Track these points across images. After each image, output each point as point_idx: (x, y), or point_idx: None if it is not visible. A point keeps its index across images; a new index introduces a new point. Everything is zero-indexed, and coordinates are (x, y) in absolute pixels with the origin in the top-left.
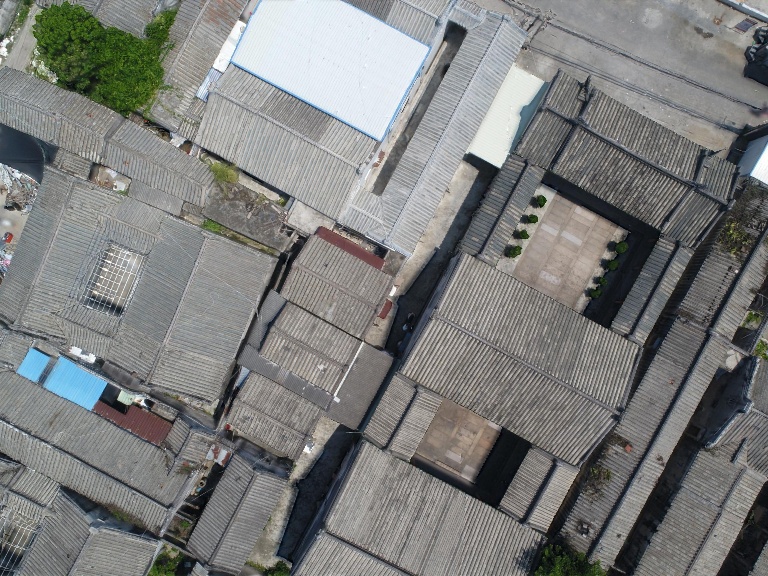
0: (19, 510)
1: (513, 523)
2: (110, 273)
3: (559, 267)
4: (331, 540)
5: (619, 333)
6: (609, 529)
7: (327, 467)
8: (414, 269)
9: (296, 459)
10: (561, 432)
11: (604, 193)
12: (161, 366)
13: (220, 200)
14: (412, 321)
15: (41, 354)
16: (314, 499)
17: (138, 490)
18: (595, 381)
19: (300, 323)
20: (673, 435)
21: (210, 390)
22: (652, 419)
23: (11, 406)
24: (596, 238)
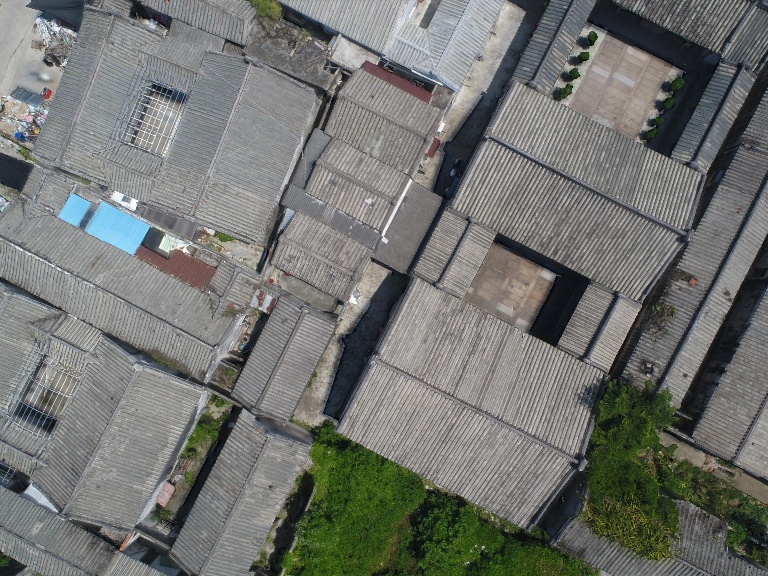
0: (61, 359)
1: (573, 360)
2: (152, 109)
3: (611, 110)
4: (384, 371)
5: (680, 162)
6: (675, 367)
7: (374, 321)
8: (460, 114)
9: (344, 301)
10: (622, 263)
11: (660, 17)
12: (205, 199)
13: (262, 38)
14: (460, 167)
15: (82, 199)
16: (361, 355)
17: (183, 330)
18: (658, 205)
19: (346, 157)
20: (740, 268)
21: (255, 229)
22: (718, 250)
23: (53, 248)
24: (650, 79)
